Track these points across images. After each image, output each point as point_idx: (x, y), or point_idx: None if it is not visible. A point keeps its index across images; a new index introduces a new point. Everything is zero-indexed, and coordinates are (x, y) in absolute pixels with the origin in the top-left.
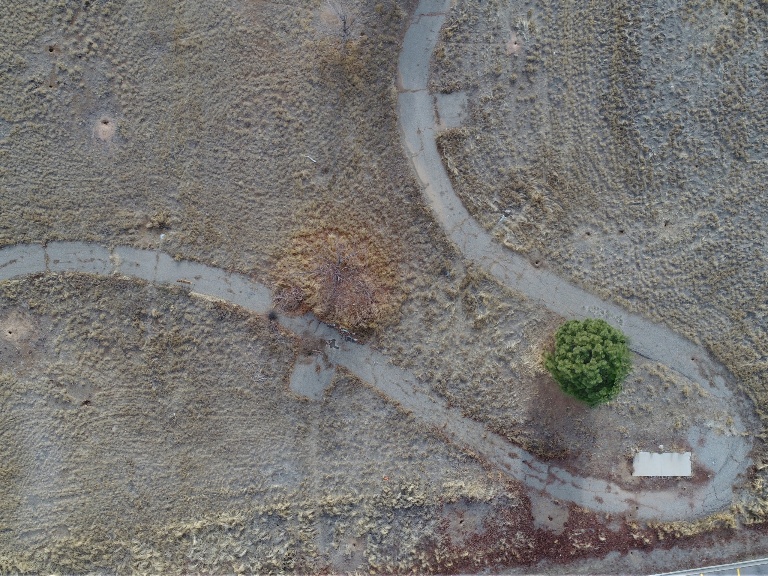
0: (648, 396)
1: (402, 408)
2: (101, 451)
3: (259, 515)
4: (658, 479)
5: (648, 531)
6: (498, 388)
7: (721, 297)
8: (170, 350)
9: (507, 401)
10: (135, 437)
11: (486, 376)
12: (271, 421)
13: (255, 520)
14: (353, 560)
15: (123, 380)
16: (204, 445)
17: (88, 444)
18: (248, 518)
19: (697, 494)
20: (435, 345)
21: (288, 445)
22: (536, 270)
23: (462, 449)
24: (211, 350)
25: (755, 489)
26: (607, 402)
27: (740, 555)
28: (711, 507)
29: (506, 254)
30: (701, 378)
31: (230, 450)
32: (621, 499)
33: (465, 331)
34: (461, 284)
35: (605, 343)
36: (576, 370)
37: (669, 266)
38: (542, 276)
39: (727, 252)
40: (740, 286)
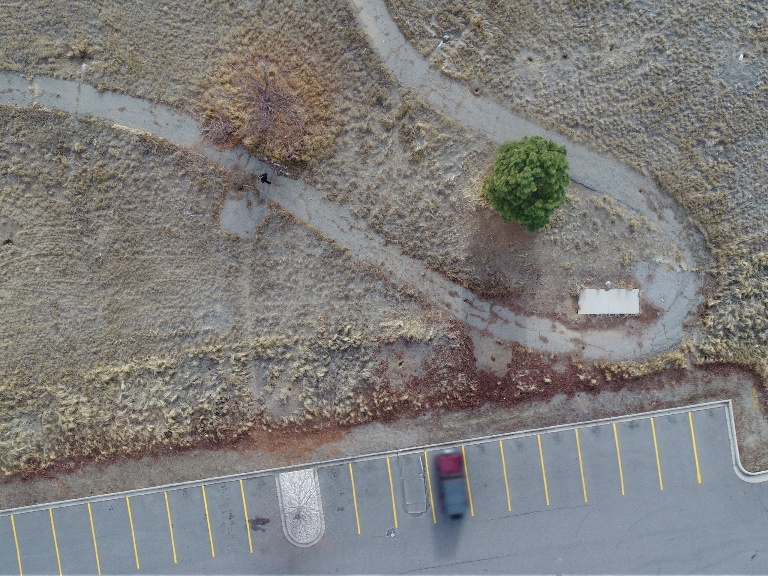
0: (594, 230)
1: (337, 245)
2: (24, 292)
3: (190, 358)
4: (605, 317)
5: (595, 372)
6: (437, 223)
7: (669, 124)
8: (94, 187)
9: (447, 237)
10: (59, 278)
11: (425, 211)
12: (201, 260)
13: (186, 363)
14: (288, 405)
15: (46, 218)
16: (132, 286)
17: (10, 285)
18: (178, 361)
19: (646, 333)
20: (371, 179)
21: (219, 285)
22: (476, 98)
23: (400, 287)
24: (137, 186)
25: (706, 326)
26: (551, 237)
27: (691, 398)
28: (660, 346)
29: (444, 82)
30: (649, 211)
31: (159, 291)
32: (567, 338)
33: (402, 164)
34: (397, 114)
35: (540, 151)
36: (510, 181)
37: (615, 92)
38: (482, 105)
39: (675, 76)
40: (689, 112)
